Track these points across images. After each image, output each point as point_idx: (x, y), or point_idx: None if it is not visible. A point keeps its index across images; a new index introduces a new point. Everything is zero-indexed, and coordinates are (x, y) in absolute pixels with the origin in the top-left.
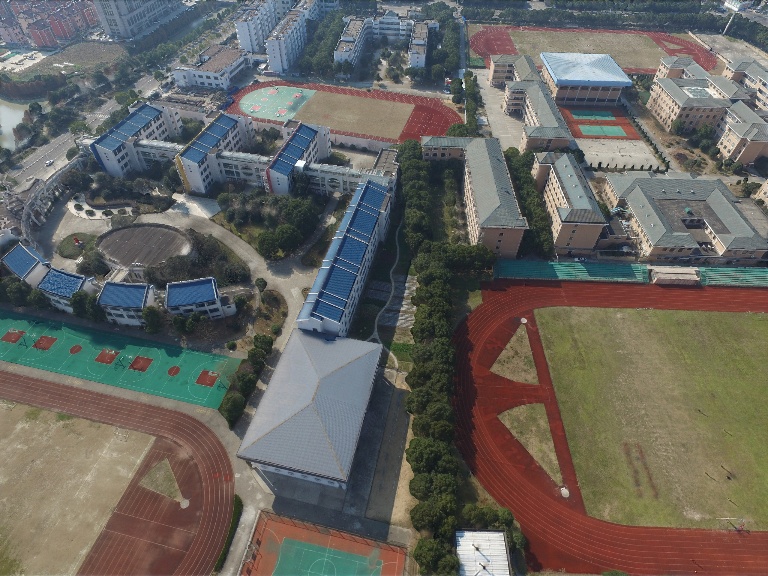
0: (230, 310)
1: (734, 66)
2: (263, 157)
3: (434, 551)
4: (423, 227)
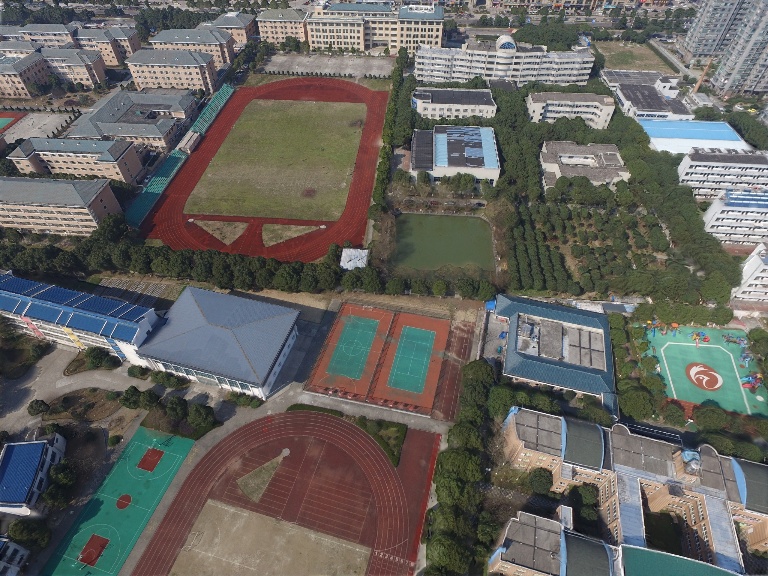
0: (60, 443)
1: None
2: None
3: (350, 274)
4: (52, 250)
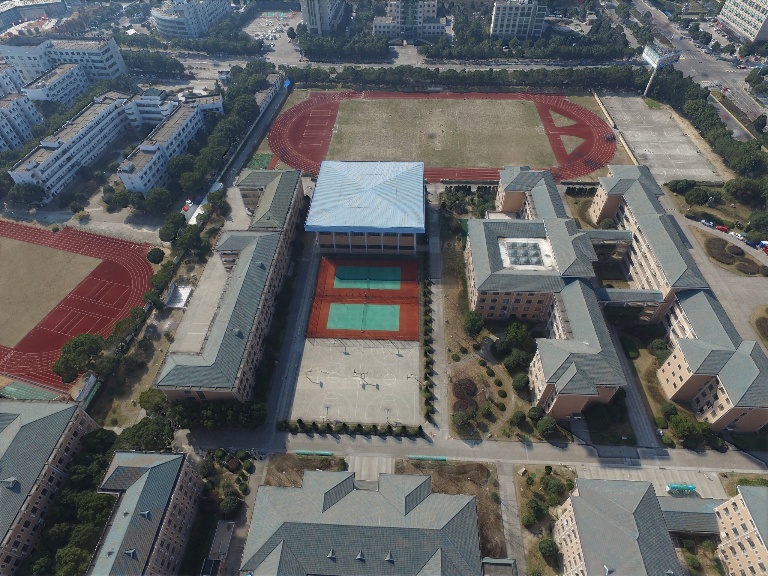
0: None
1: (608, 185)
2: None
3: None
4: None
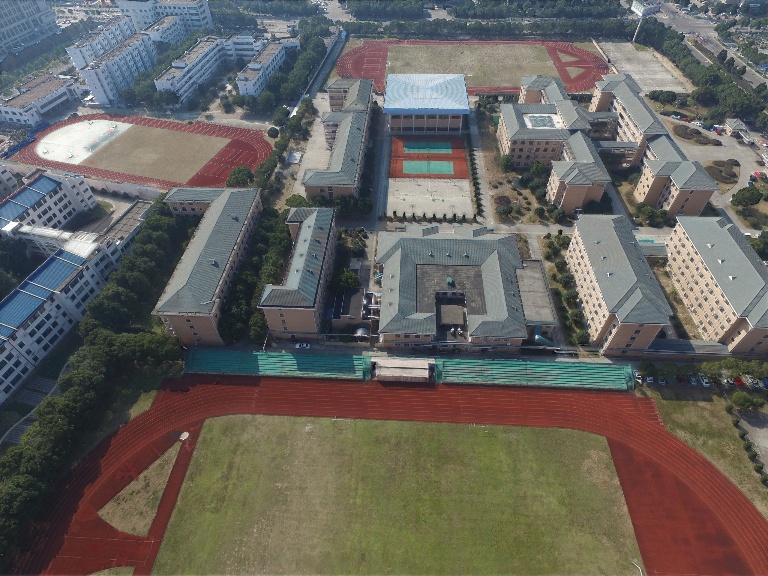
0: None
1: (601, 85)
2: None
3: None
4: (104, 310)
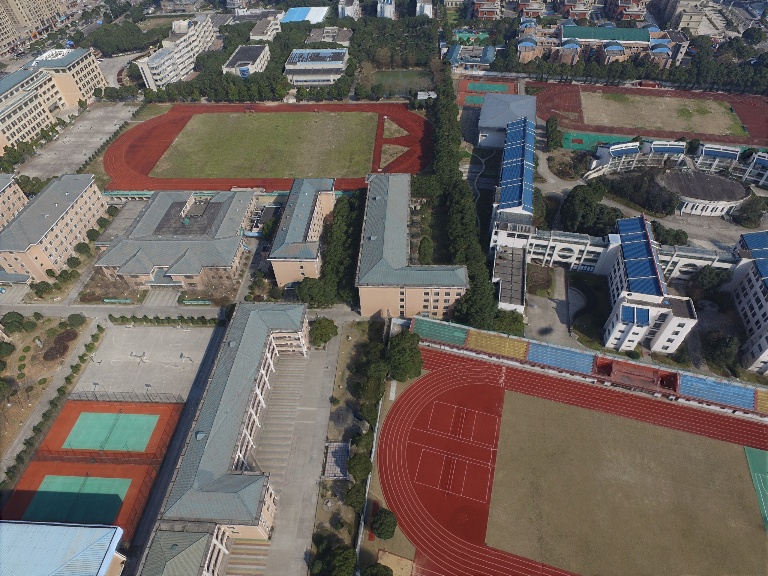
0: None
1: None
2: (671, 250)
3: None
4: None
